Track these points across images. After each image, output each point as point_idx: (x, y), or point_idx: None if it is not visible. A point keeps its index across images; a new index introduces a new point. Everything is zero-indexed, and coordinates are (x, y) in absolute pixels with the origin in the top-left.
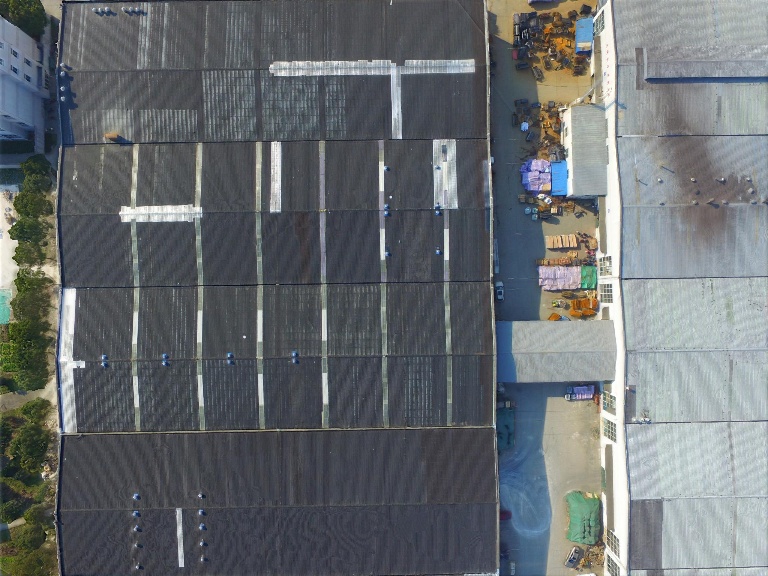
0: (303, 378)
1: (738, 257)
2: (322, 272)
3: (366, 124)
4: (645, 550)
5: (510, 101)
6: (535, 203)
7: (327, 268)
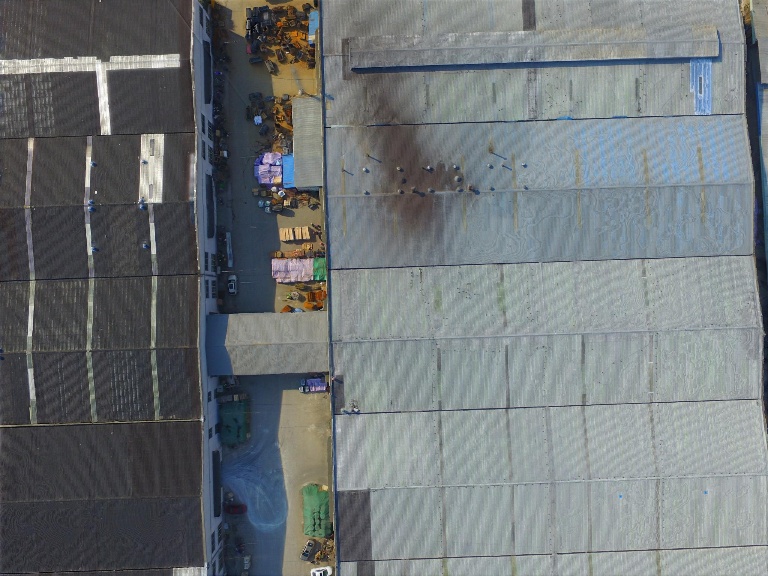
0: (9, 374)
1: (447, 245)
2: (30, 268)
3: (74, 120)
4: (354, 541)
5: (245, 95)
6: (268, 196)
7: (35, 264)
